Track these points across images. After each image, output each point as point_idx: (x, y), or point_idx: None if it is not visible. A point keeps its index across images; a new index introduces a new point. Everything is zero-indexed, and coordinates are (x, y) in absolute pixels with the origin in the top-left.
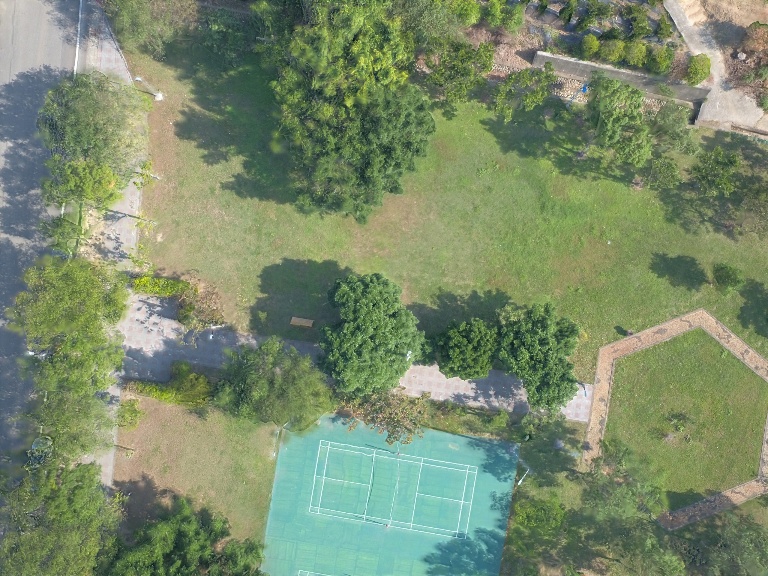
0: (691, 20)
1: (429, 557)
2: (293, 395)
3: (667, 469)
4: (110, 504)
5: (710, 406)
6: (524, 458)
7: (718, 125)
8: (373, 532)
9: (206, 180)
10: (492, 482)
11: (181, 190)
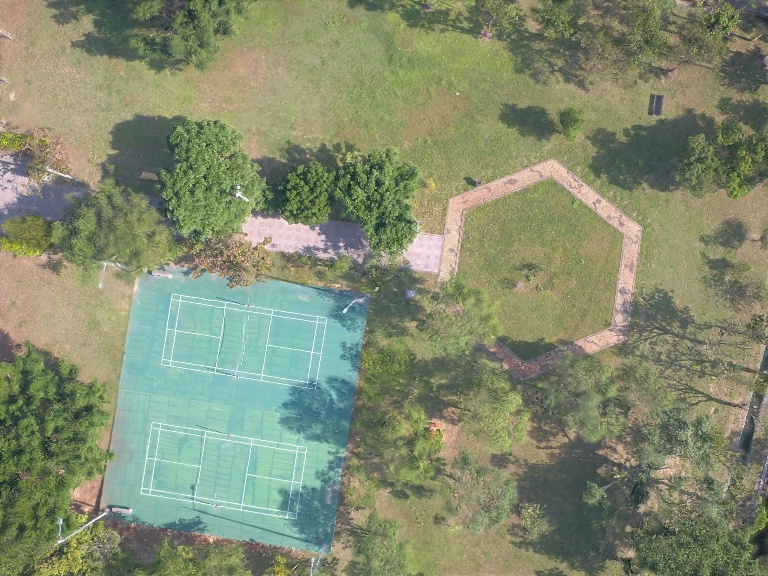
0: None
1: (279, 407)
2: None
3: (518, 319)
4: None
5: (561, 255)
6: (374, 309)
7: None
8: (224, 383)
9: (57, 39)
10: (342, 333)
11: (33, 50)
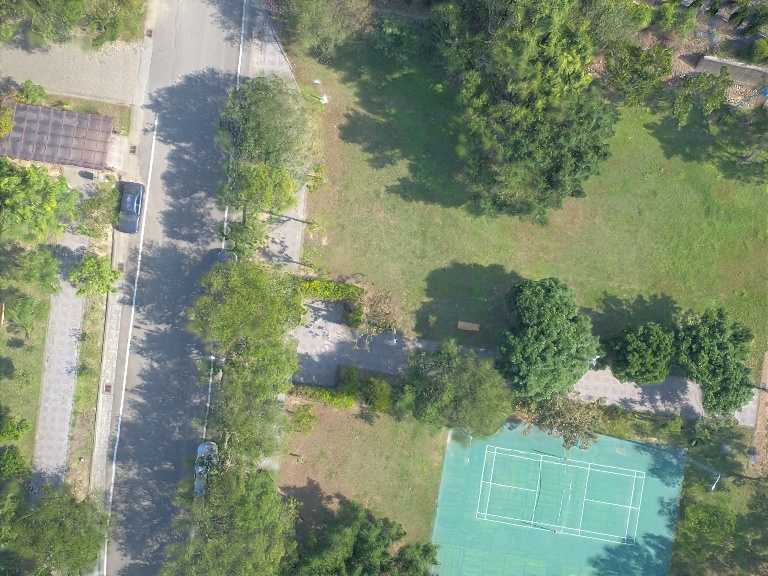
0: None
1: (598, 563)
2: (481, 400)
3: None
4: (286, 510)
5: None
6: (691, 463)
7: None
8: (541, 538)
9: (371, 184)
10: (660, 487)
11: (346, 194)
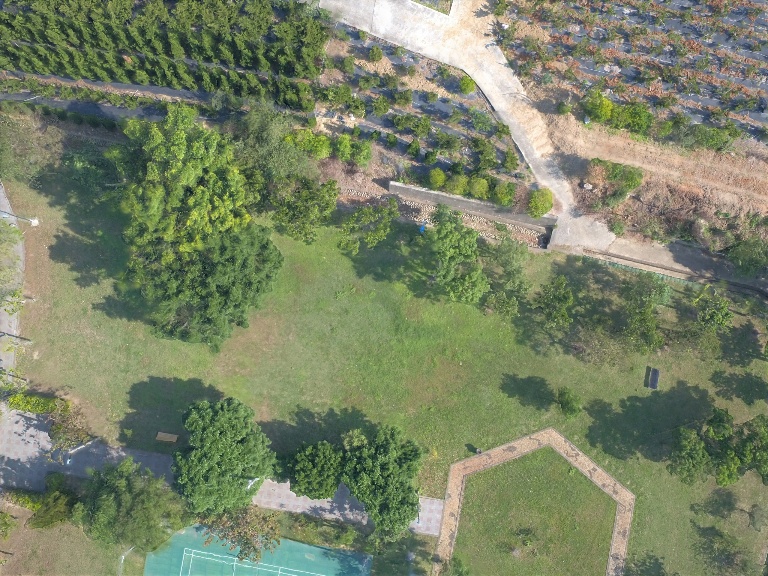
0: (538, 152)
1: None
2: (141, 519)
3: None
4: None
5: (557, 522)
6: (377, 569)
7: (570, 249)
8: None
9: (79, 301)
10: None
11: (56, 311)
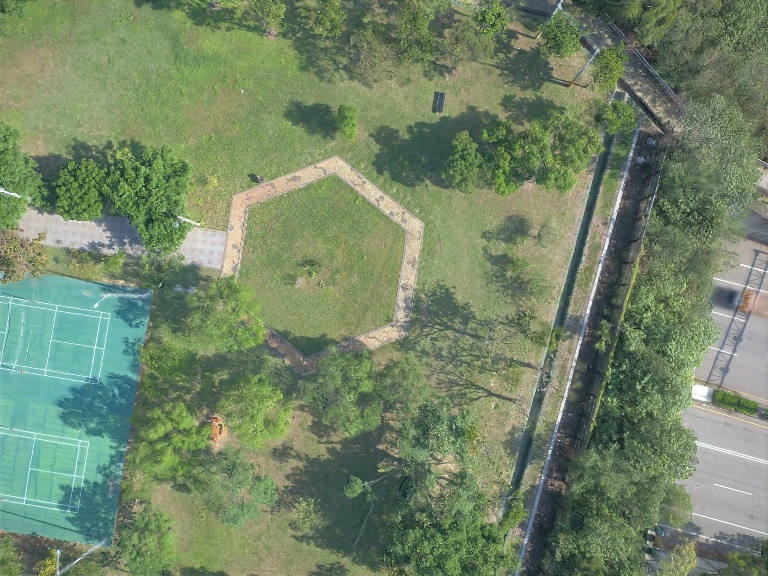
0: None
1: (62, 402)
2: None
3: (300, 314)
4: None
5: (344, 252)
6: (157, 305)
7: None
8: (8, 378)
9: None
10: (124, 328)
11: None
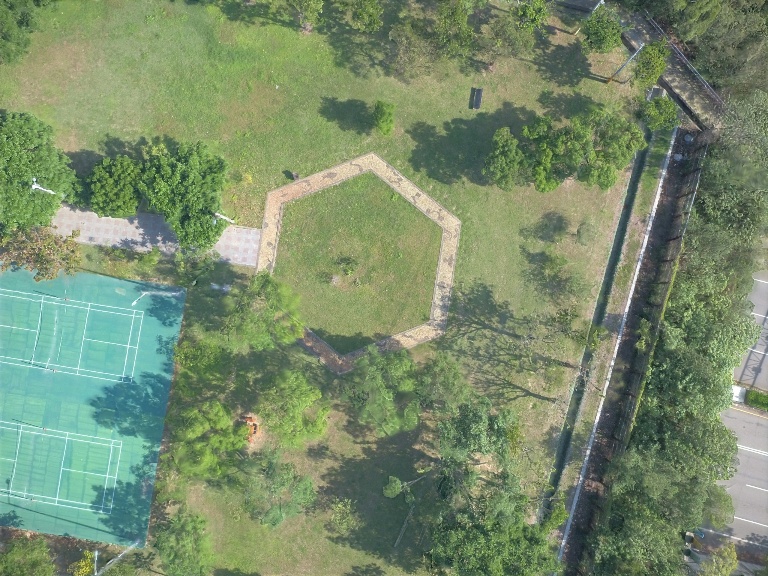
0: None
1: (95, 401)
2: None
3: (336, 313)
4: None
5: (380, 249)
6: (191, 303)
7: None
8: (40, 377)
9: None
10: (158, 326)
11: None
